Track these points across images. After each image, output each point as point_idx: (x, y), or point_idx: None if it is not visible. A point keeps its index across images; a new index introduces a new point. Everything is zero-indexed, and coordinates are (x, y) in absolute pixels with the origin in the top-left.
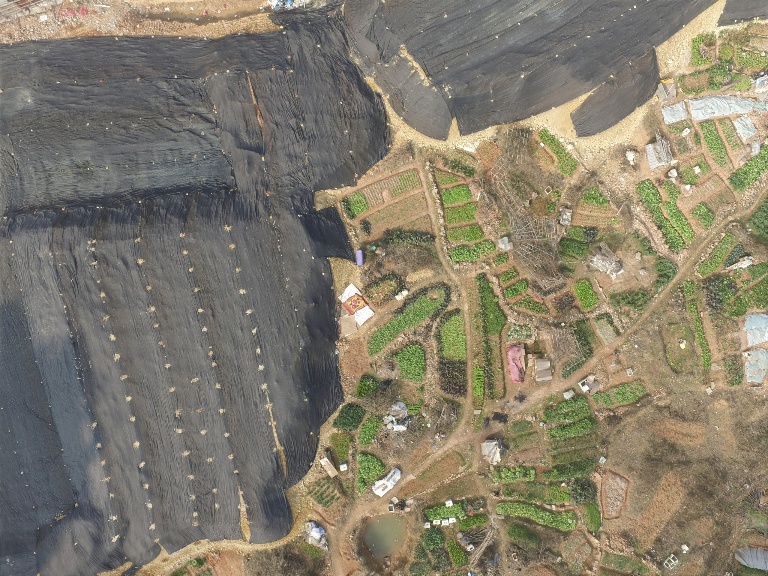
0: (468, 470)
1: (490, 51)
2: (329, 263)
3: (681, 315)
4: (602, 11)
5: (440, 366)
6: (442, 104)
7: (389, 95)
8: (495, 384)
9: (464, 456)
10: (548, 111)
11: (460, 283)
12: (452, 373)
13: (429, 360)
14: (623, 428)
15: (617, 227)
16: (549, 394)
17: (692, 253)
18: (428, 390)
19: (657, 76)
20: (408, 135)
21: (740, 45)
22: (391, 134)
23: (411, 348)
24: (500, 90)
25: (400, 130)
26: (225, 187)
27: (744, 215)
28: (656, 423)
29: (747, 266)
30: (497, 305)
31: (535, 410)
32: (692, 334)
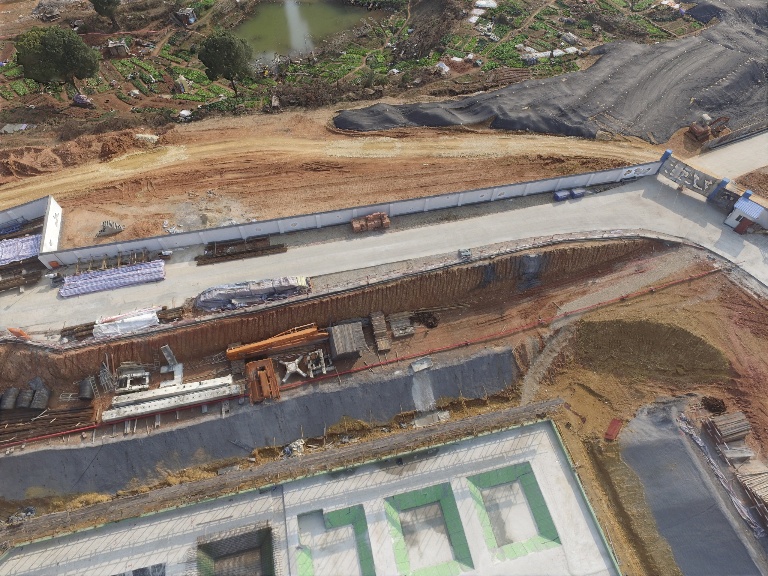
0: None
1: (685, 48)
2: (696, 3)
3: None
4: (641, 62)
5: None
6: None
7: None
8: None
9: None
10: None
11: None
12: None
13: None
14: None
15: None
16: None
17: None
18: None
19: None
20: None
21: None
22: None
23: None
24: None
25: None
26: (759, 26)
27: None
28: None
29: None
30: None
31: None
32: None
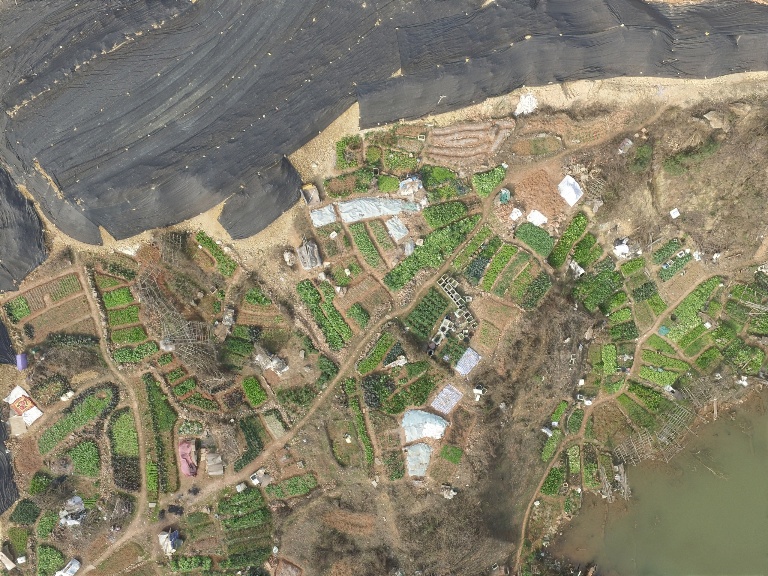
0: (148, 559)
1: (121, 163)
2: None
3: (344, 411)
4: (231, 121)
5: (112, 462)
6: (79, 215)
7: (39, 203)
8: (169, 478)
9: (142, 546)
10: (198, 216)
11: (127, 382)
12: (124, 469)
13: (103, 456)
14: (295, 519)
15: (282, 325)
16: (223, 487)
17: (352, 351)
18: (104, 485)
19: (298, 182)
20: (65, 240)
21: (387, 147)
22: (48, 240)
23: (84, 445)
24: (138, 200)
25: (57, 236)
26: None
27: (402, 314)
28: (326, 514)
29: (405, 364)
30: (166, 403)
31: (210, 502)
32: (355, 430)
